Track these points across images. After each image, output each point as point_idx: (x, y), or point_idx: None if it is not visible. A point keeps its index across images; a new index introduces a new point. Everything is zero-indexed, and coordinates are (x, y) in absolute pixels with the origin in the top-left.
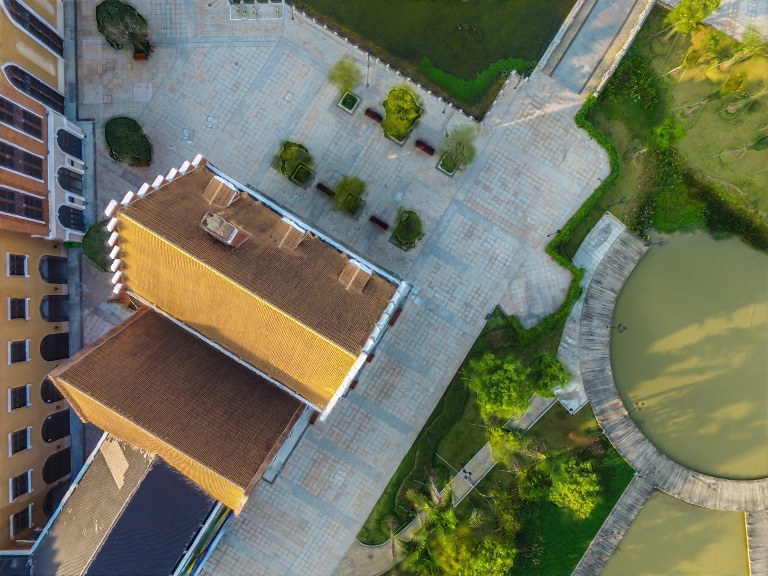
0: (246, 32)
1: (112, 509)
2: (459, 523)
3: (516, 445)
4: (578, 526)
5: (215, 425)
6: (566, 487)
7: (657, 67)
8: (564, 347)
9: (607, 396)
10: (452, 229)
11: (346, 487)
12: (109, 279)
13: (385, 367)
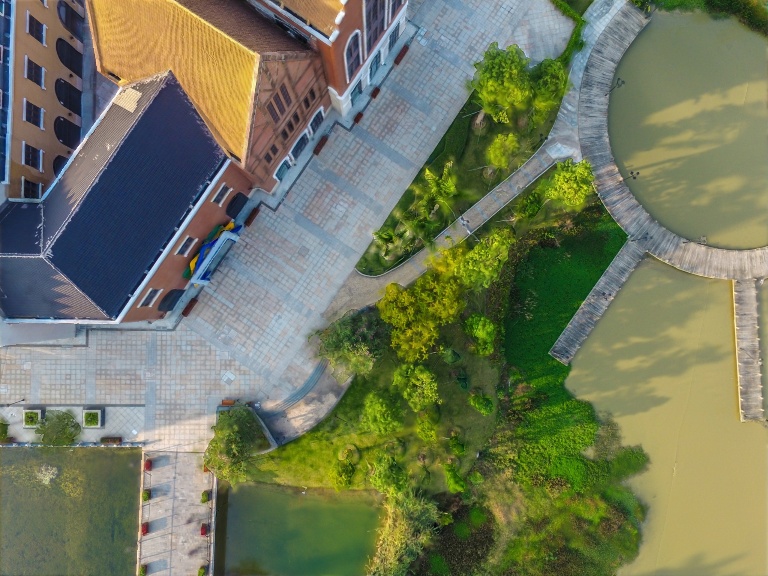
0: None
1: (124, 128)
2: None
3: (515, 142)
4: (571, 286)
5: (229, 21)
6: (562, 175)
7: None
8: (563, 113)
9: (603, 162)
10: None
11: (347, 218)
12: None
13: (389, 104)
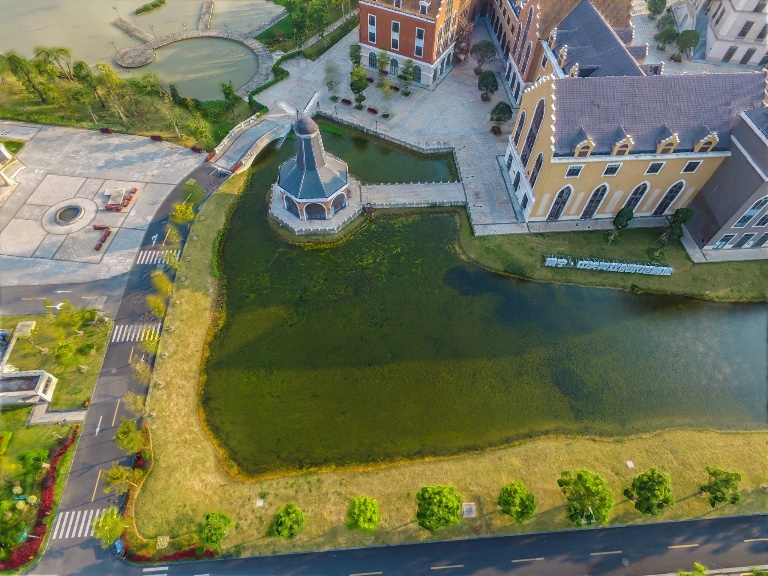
0: (443, 138)
1: None
2: (333, 17)
3: None
4: (281, 26)
5: None
6: None
7: (214, 144)
8: None
9: (262, 55)
10: (334, 80)
11: None
12: (490, 66)
13: None
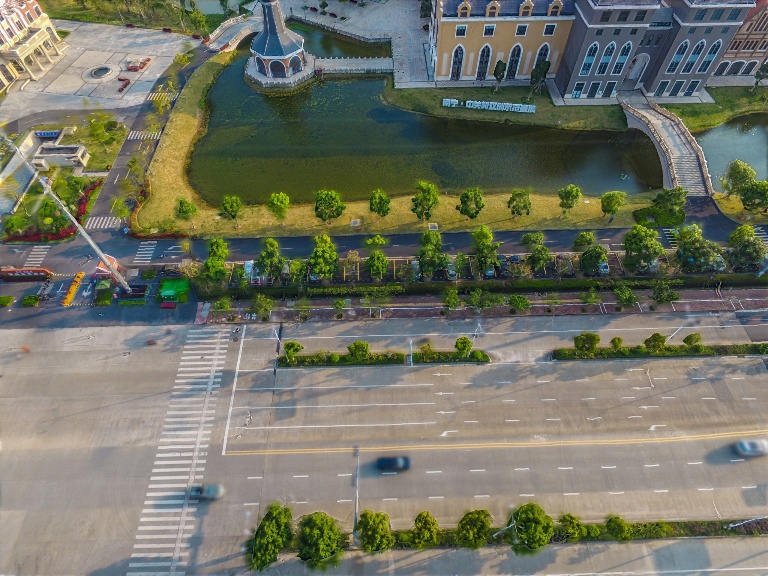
0: (385, 32)
1: None
2: None
3: None
4: None
5: None
6: None
7: None
8: None
9: None
10: None
11: None
12: None
13: None
